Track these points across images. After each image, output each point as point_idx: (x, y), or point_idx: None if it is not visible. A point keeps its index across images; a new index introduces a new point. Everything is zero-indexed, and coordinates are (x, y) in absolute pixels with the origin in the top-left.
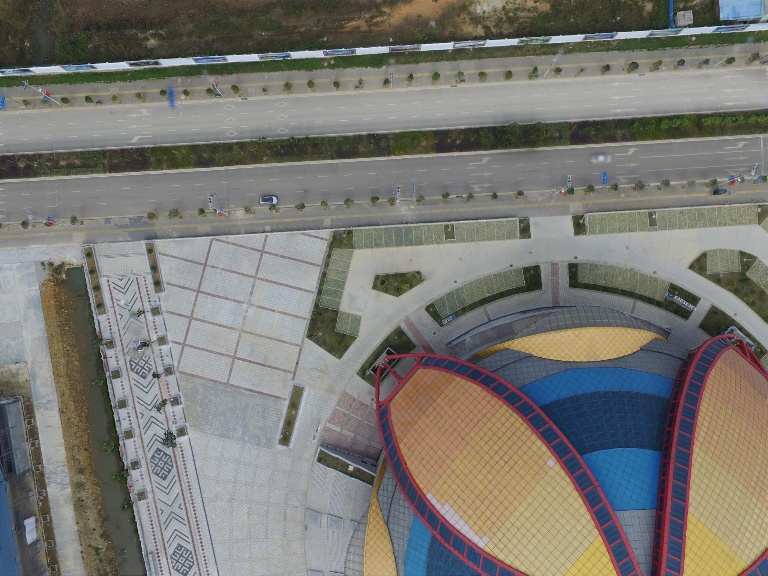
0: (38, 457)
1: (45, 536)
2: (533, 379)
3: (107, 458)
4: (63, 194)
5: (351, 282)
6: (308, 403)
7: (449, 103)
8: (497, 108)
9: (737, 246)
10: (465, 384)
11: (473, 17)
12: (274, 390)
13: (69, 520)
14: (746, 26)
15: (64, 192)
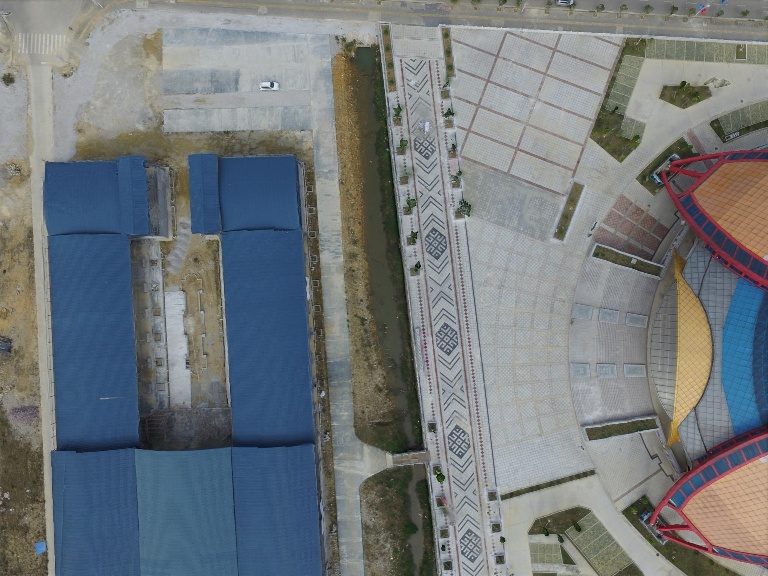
0: (314, 224)
1: (313, 301)
2: None
3: (377, 235)
4: None
5: (639, 89)
6: (585, 202)
7: None
8: None
9: None
10: None
11: None
12: (553, 185)
13: (338, 288)
14: None
15: None
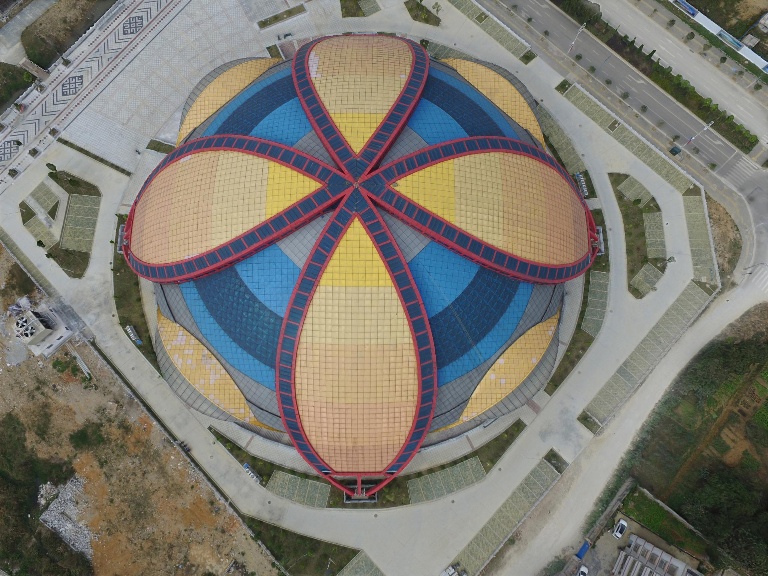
0: None
1: None
2: (442, 71)
3: None
4: None
5: None
6: (298, 21)
7: None
8: None
9: (654, 193)
10: None
11: None
12: None
13: None
14: None
15: None
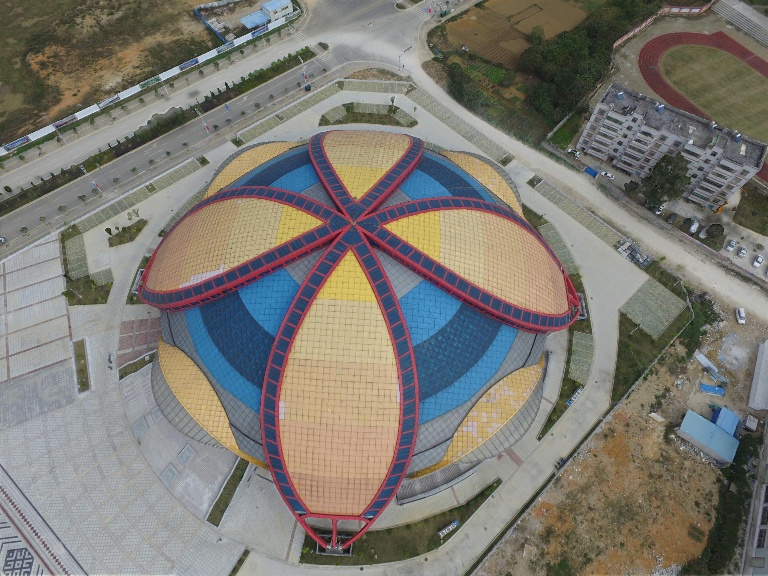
0: None
1: None
2: None
3: None
4: None
5: (90, 253)
6: (93, 348)
7: (113, 132)
8: (147, 120)
9: (338, 104)
10: (181, 224)
11: (105, 91)
12: (57, 358)
13: None
14: (266, 27)
15: None
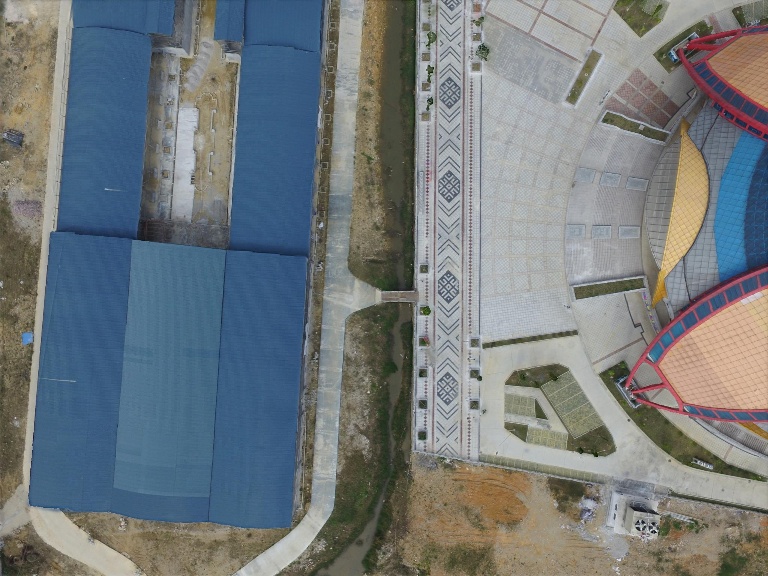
0: (333, 60)
1: (323, 134)
2: None
3: (394, 81)
4: None
5: None
6: (601, 71)
7: None
8: None
9: None
10: None
11: None
12: (572, 51)
13: (349, 125)
14: None
15: None
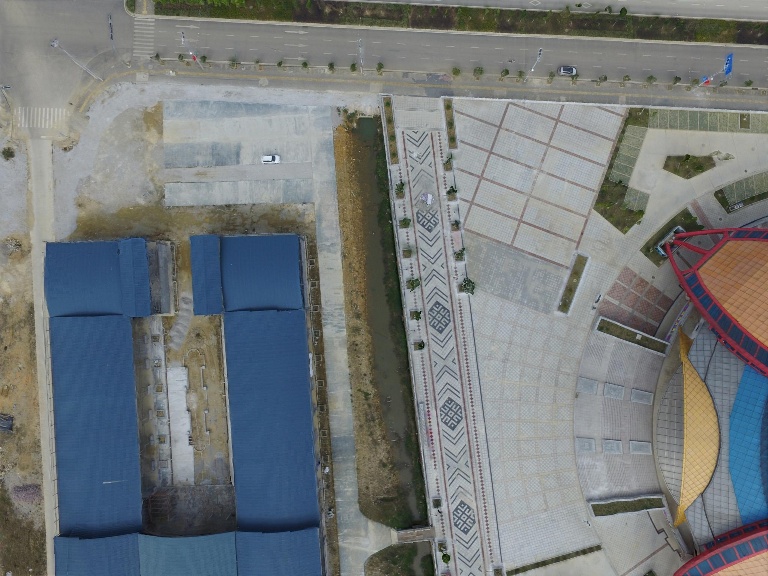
0: (316, 298)
1: (317, 376)
2: None
3: (381, 308)
4: (364, 44)
5: (642, 160)
6: (589, 274)
7: None
8: None
9: None
10: None
11: None
12: (557, 257)
13: (342, 363)
14: None
15: (366, 42)
